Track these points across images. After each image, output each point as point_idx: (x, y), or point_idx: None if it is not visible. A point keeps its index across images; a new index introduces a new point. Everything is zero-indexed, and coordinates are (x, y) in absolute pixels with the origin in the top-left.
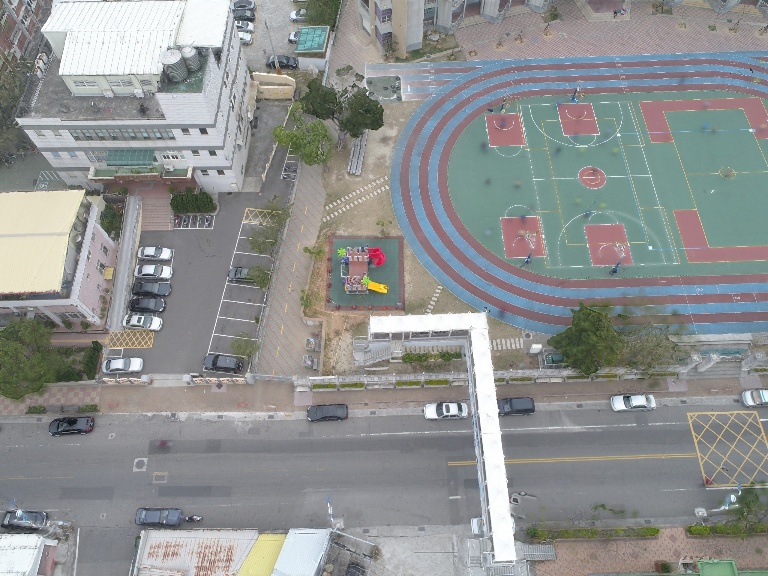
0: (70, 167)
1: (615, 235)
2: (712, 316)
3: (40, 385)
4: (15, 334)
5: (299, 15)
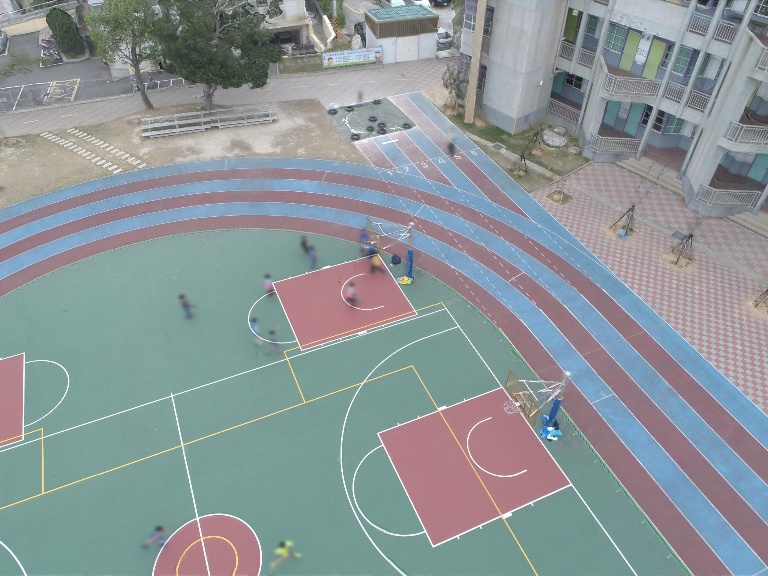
0: None
1: None
2: None
3: None
4: None
5: None
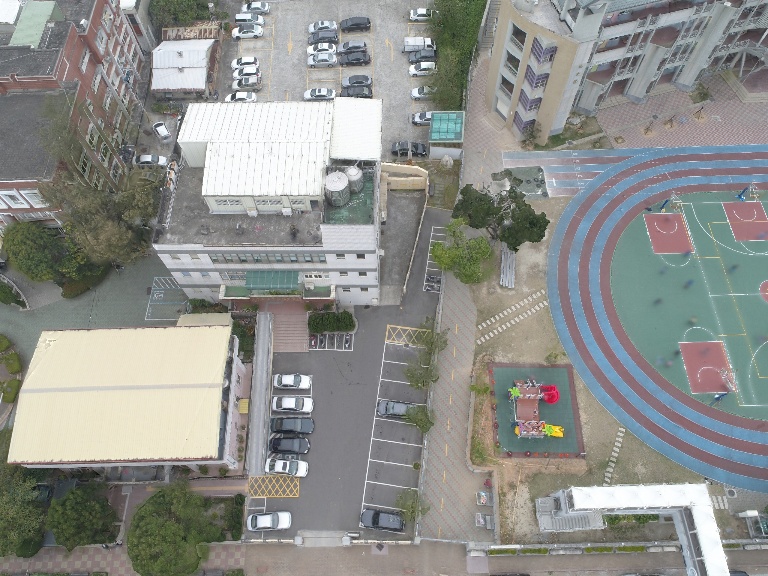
0: (198, 284)
1: None
2: None
3: (196, 567)
4: (165, 505)
5: (422, 93)
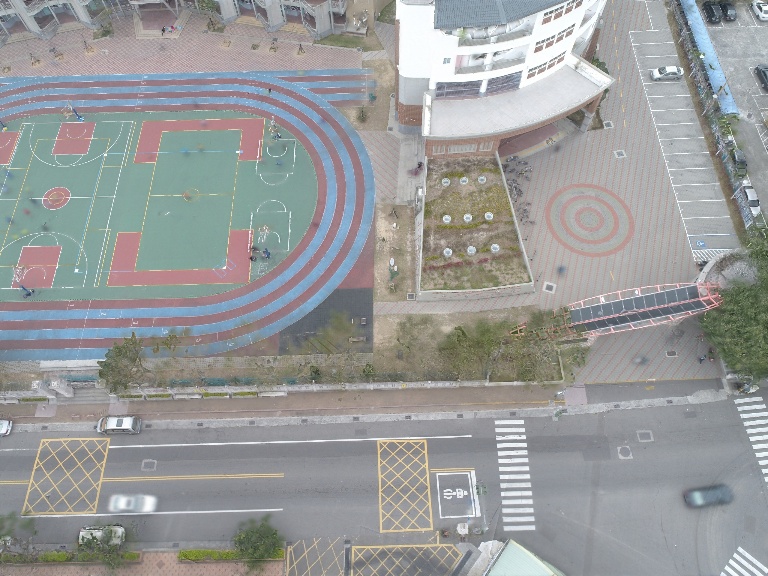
0: None
1: (48, 257)
2: (101, 341)
3: None
4: None
5: None
